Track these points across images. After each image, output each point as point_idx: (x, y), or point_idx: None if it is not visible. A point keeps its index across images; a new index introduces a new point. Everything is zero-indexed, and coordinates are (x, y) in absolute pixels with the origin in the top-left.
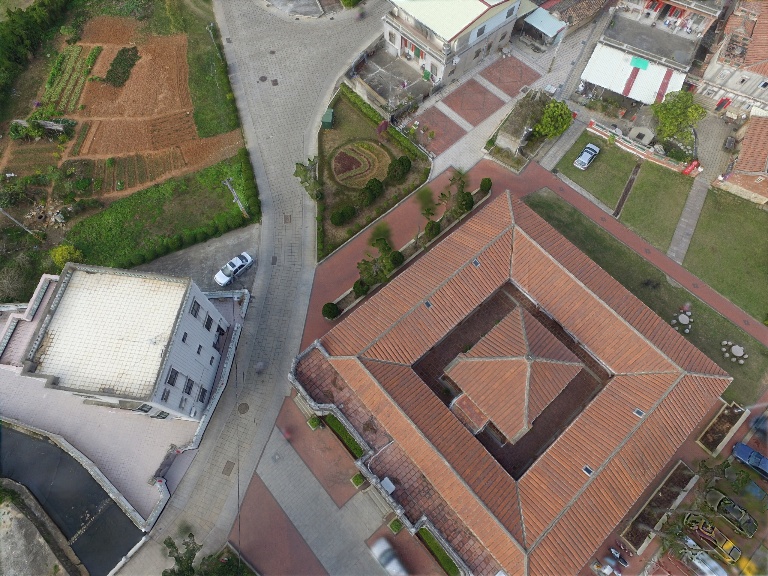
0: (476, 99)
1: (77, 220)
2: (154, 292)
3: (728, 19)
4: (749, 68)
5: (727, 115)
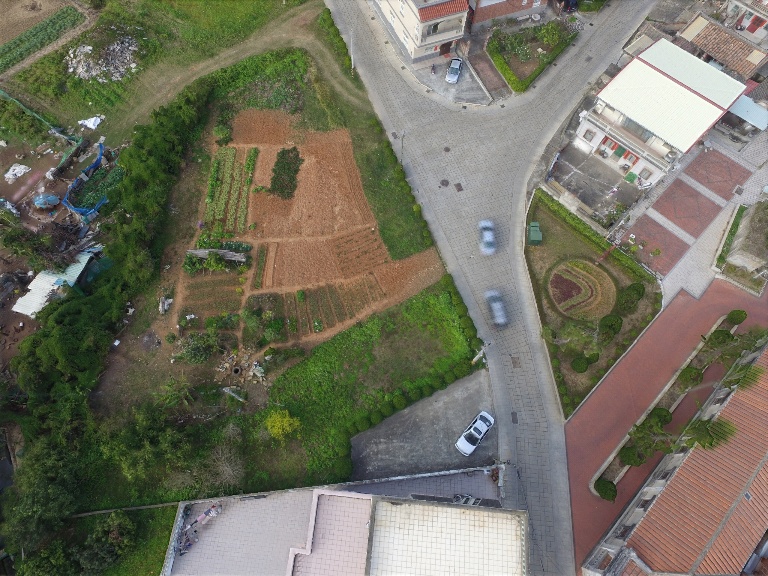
0: (689, 204)
1: (278, 372)
2: (480, 528)
3: None
4: None
5: None
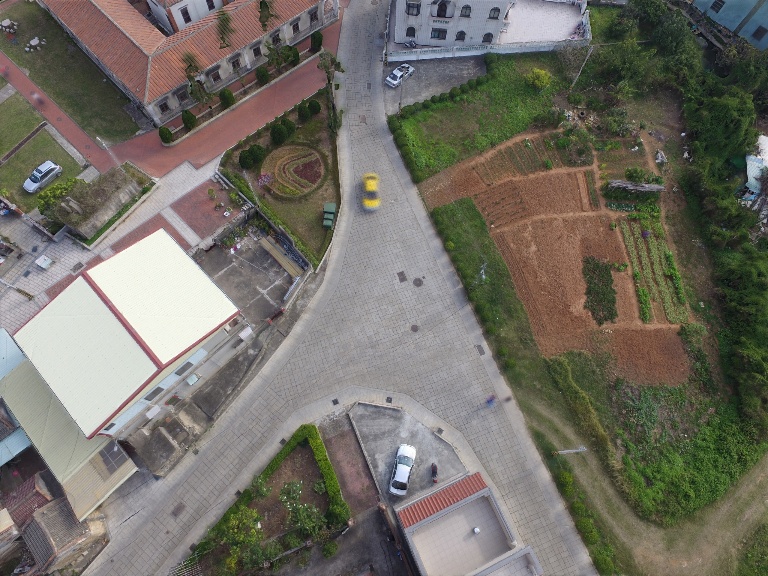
0: None
1: None
2: None
3: None
4: None
5: None
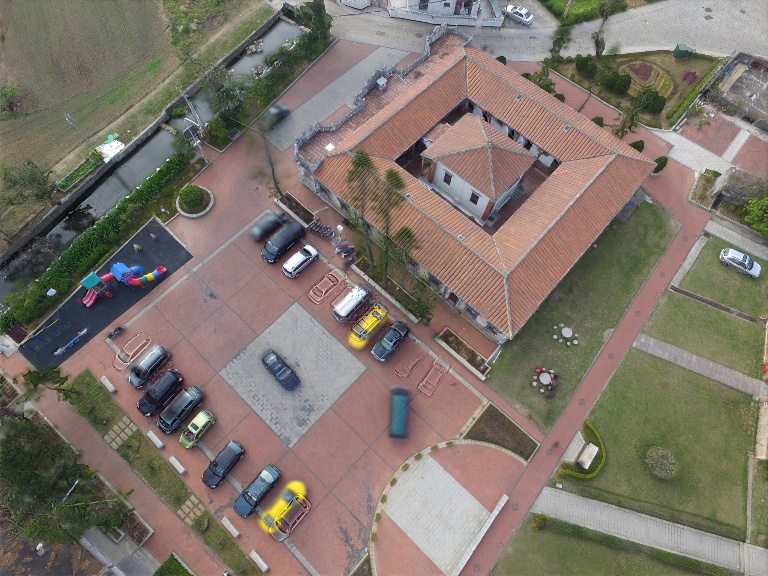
0: None
1: None
2: None
3: None
4: None
5: None
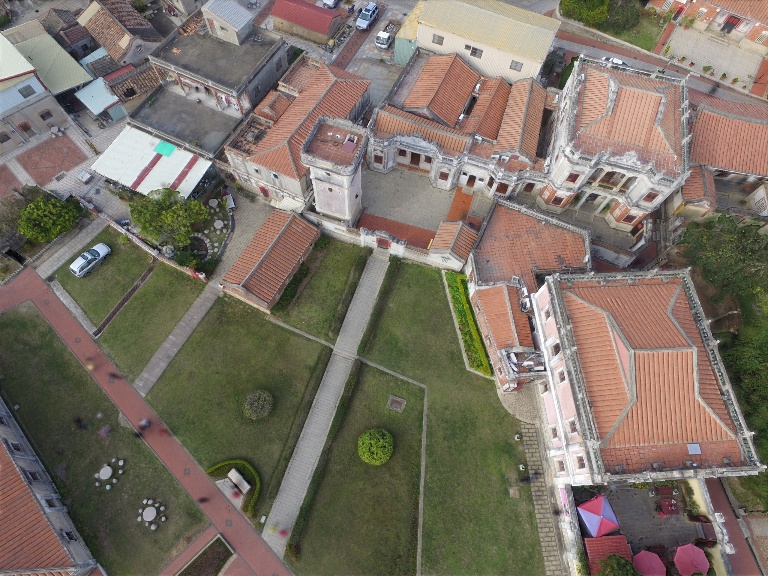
0: None
1: None
2: None
3: (266, 96)
4: (252, 158)
5: (270, 204)
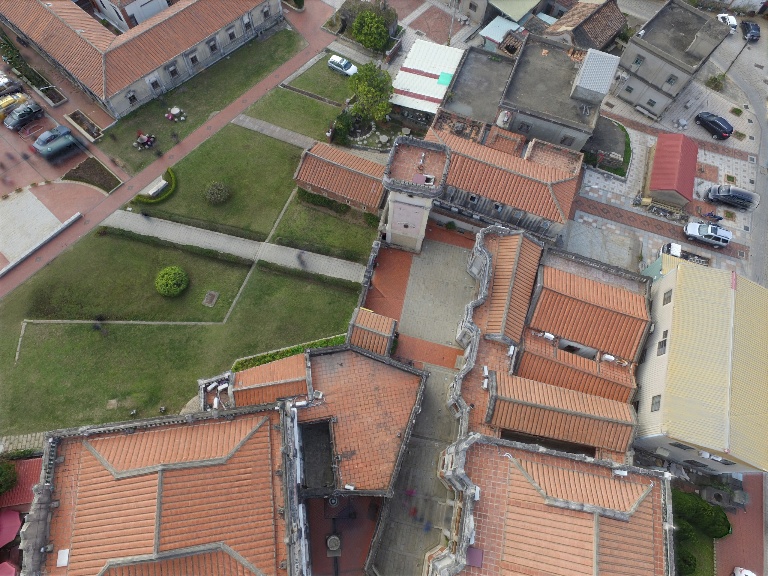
0: (401, 3)
1: None
2: None
3: None
4: (430, 131)
5: None
